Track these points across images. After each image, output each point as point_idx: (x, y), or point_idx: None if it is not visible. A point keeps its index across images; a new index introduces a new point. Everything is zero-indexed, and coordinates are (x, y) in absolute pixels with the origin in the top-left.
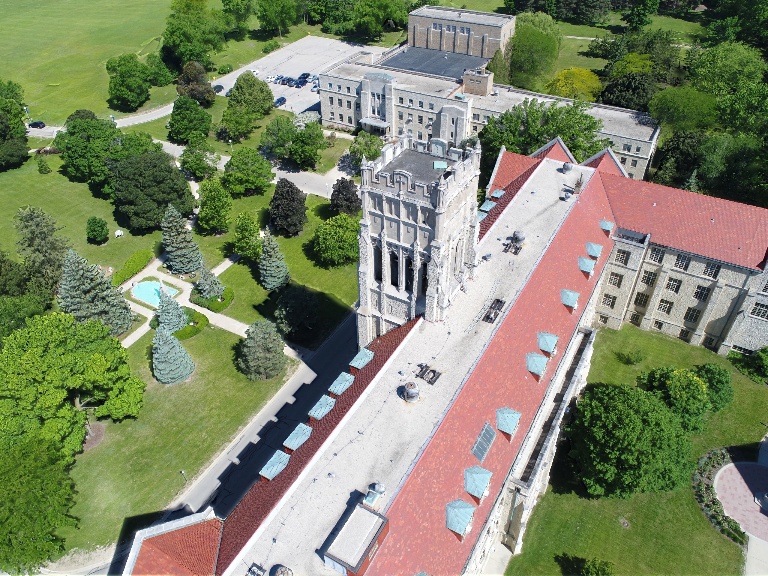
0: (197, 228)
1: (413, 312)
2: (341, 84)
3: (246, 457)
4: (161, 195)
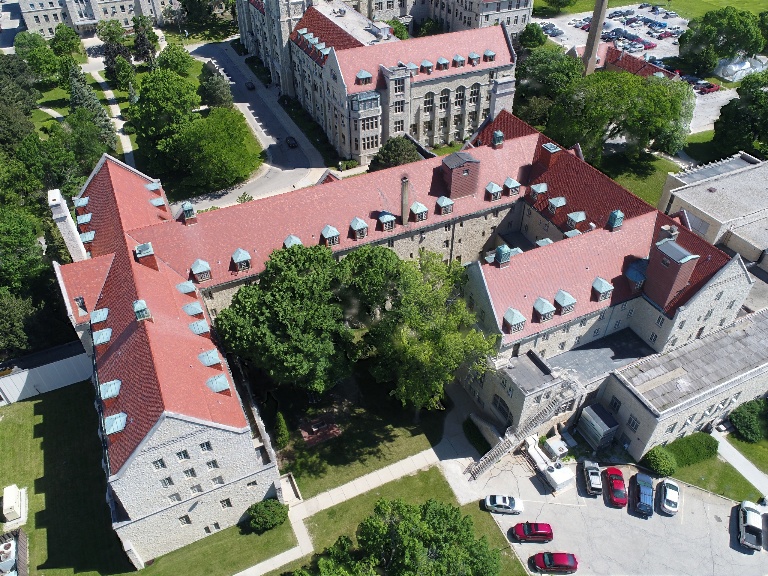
0: (56, 107)
1: (306, 6)
2: (42, 1)
3: (266, 127)
4: (29, 80)
